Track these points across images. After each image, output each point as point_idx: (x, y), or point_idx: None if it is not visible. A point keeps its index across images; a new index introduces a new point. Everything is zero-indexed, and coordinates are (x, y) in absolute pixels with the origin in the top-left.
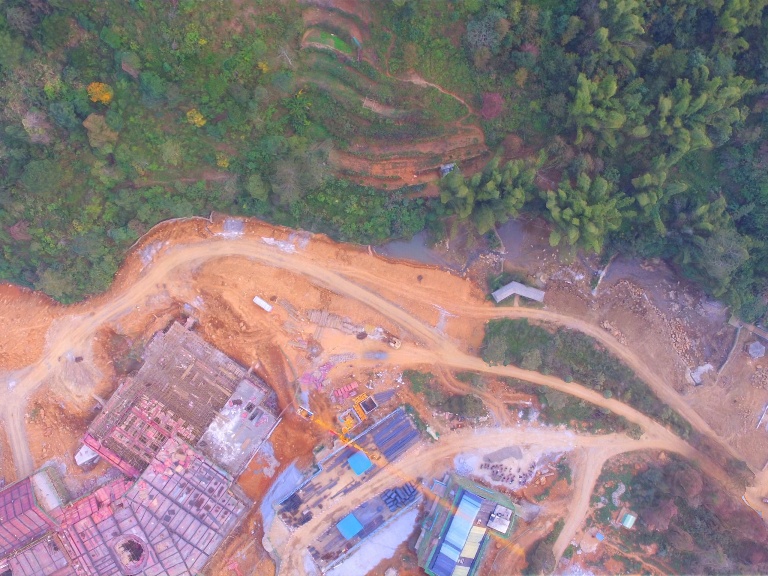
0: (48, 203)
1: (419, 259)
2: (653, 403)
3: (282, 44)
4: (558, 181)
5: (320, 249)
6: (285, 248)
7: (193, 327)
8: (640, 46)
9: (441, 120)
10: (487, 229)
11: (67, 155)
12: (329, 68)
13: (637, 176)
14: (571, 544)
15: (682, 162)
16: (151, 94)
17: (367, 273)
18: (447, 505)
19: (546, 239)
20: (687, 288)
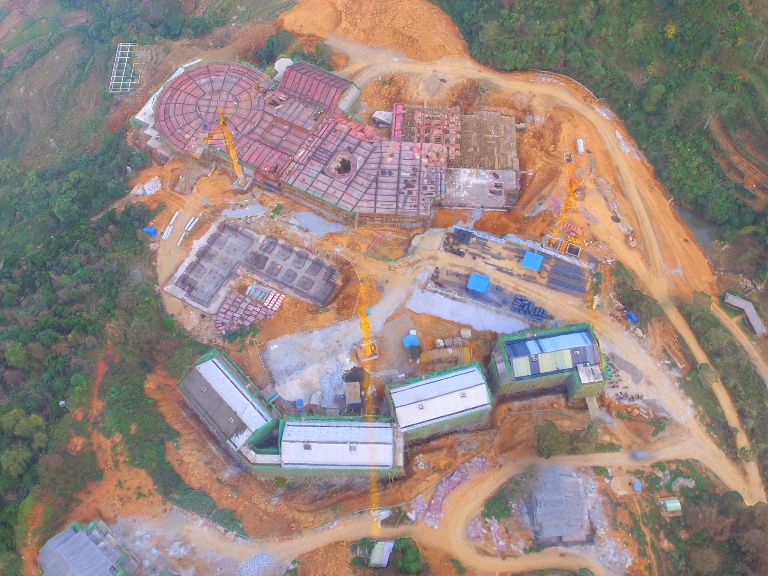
0: (540, 1)
1: (696, 236)
2: None
3: (762, 46)
4: None
5: (642, 168)
6: (623, 146)
7: (518, 130)
8: None
9: None
10: None
11: None
12: None
13: None
14: (607, 468)
15: None
16: None
17: (656, 205)
18: None
19: None
20: None
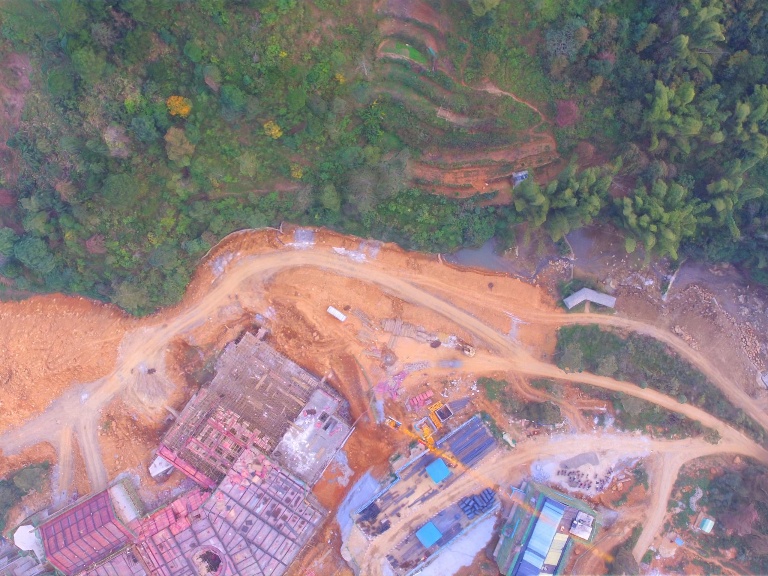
0: (124, 216)
1: (489, 267)
2: (727, 407)
3: (358, 55)
4: (634, 188)
5: (391, 258)
6: (356, 257)
7: (264, 337)
8: (717, 52)
9: (514, 128)
10: (560, 236)
11: (143, 168)
12: (403, 78)
13: (709, 181)
14: (650, 549)
15: (753, 167)
16: (231, 107)
17: (438, 281)
18: (528, 512)
19: (615, 245)
20: (756, 292)
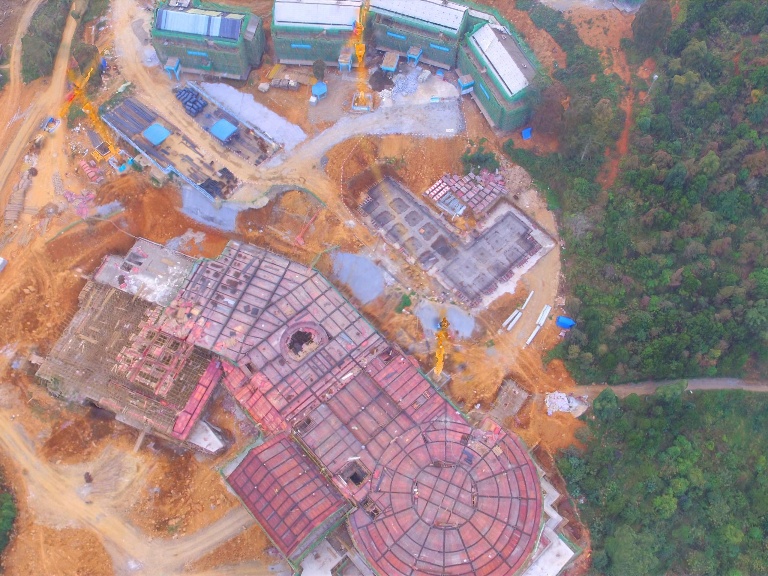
0: None
1: None
2: None
3: None
4: None
5: None
6: None
7: None
8: None
9: None
10: None
11: None
12: None
13: None
14: None
15: None
16: None
17: None
18: None
19: None
20: None
